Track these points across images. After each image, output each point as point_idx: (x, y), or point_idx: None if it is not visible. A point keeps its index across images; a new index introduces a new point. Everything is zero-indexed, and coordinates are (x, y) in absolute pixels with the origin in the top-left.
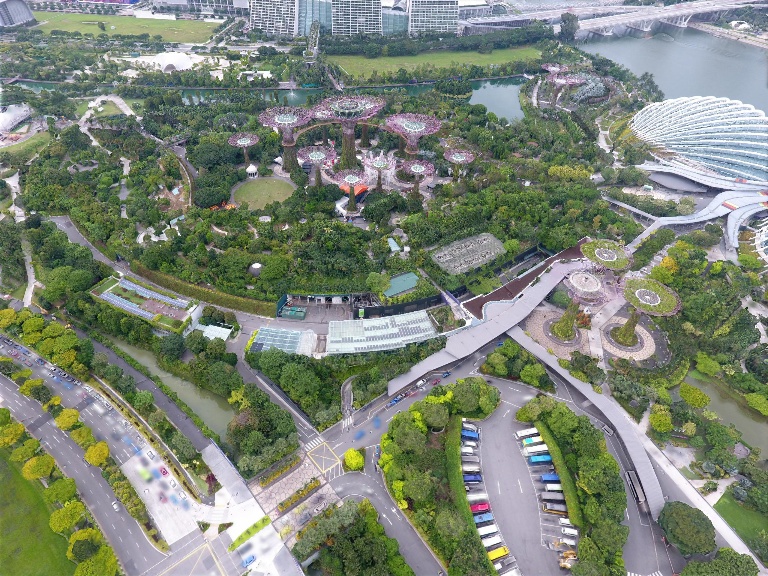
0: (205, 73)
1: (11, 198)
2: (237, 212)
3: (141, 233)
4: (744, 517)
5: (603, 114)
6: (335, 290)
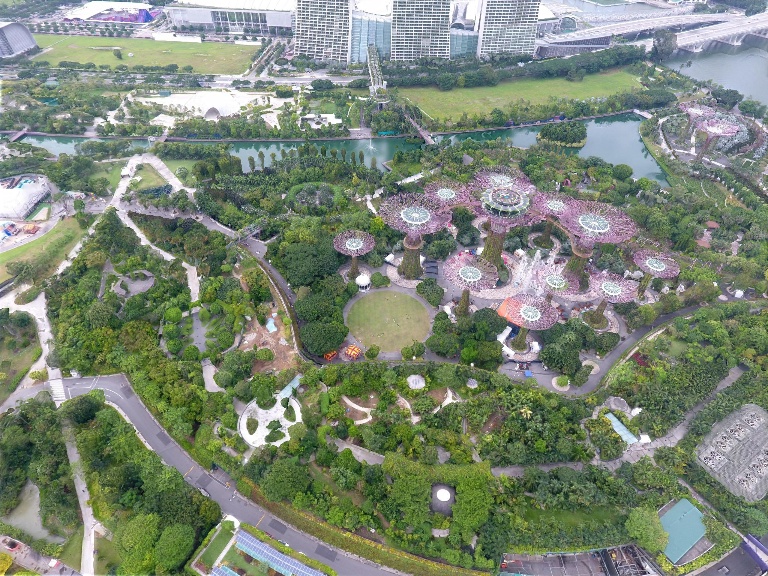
0: (259, 121)
1: (38, 342)
2: (376, 374)
3: (241, 415)
4: None
5: None
6: (580, 544)
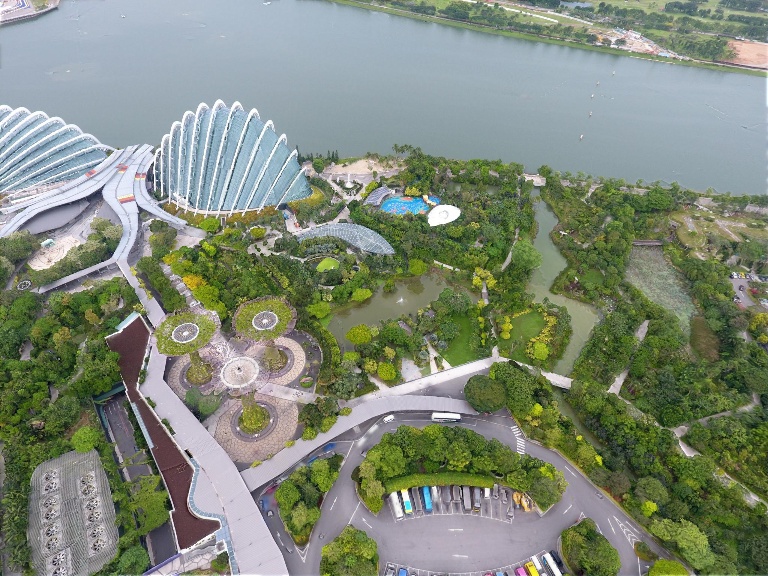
0: None
1: None
2: None
3: None
4: (457, 351)
5: None
6: None
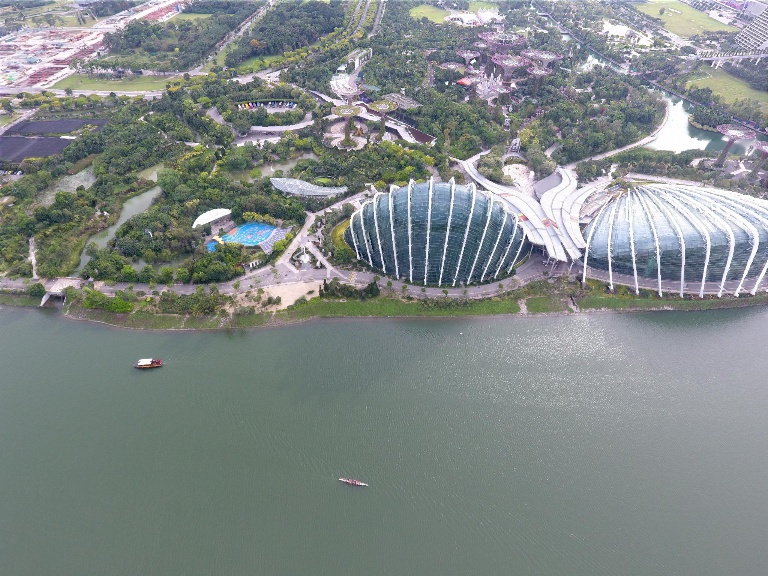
0: (603, 39)
1: None
2: None
3: None
4: None
5: None
6: None
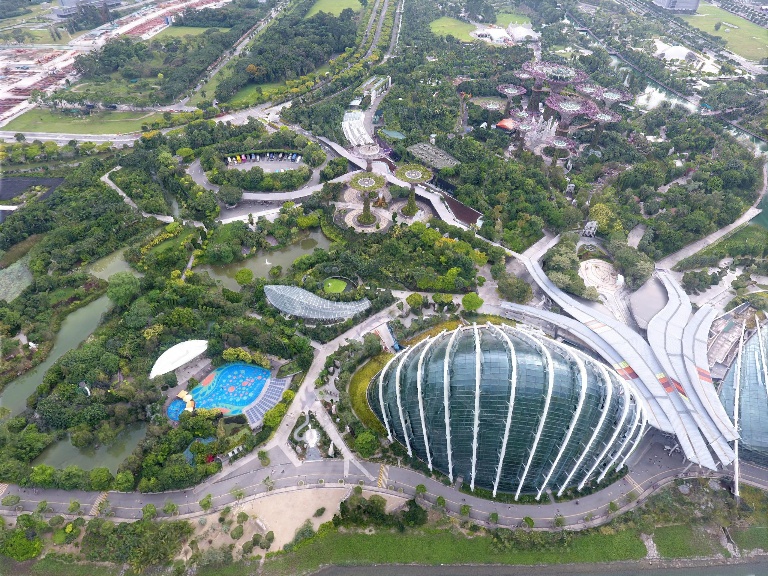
0: (661, 64)
1: None
2: None
3: None
4: None
5: None
6: None
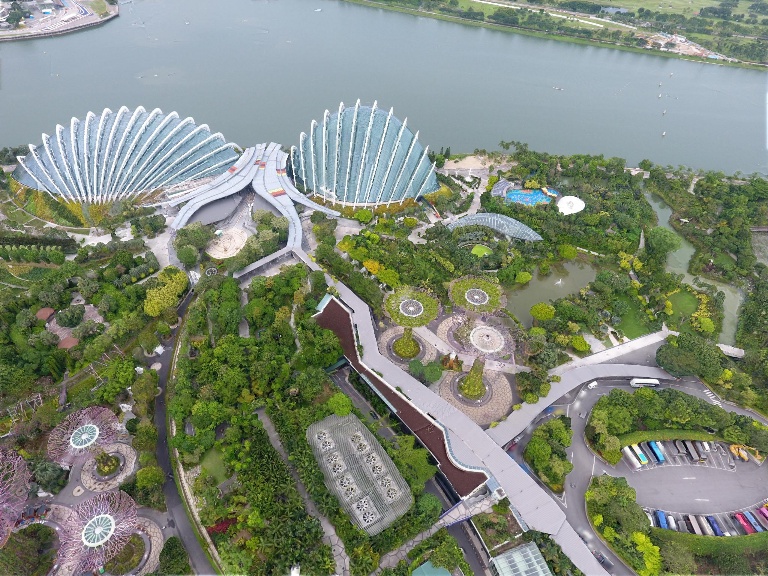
0: None
1: None
2: None
3: None
4: (629, 326)
5: (6, 211)
6: None
